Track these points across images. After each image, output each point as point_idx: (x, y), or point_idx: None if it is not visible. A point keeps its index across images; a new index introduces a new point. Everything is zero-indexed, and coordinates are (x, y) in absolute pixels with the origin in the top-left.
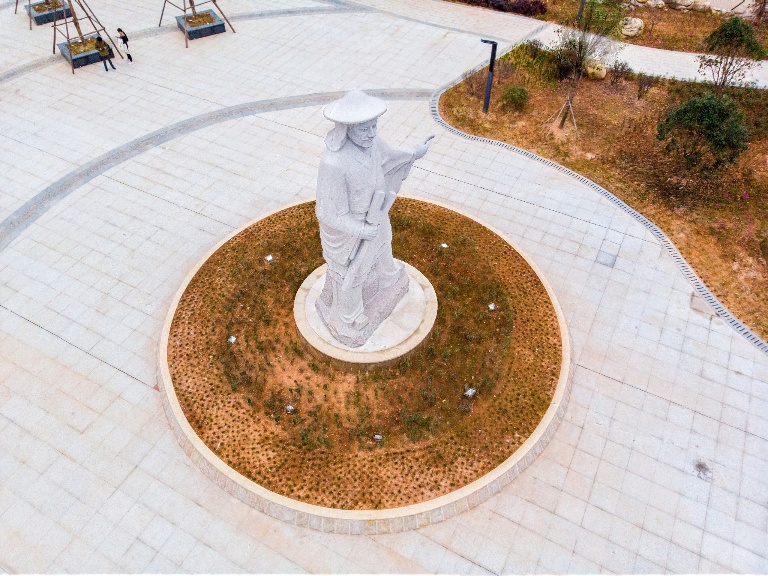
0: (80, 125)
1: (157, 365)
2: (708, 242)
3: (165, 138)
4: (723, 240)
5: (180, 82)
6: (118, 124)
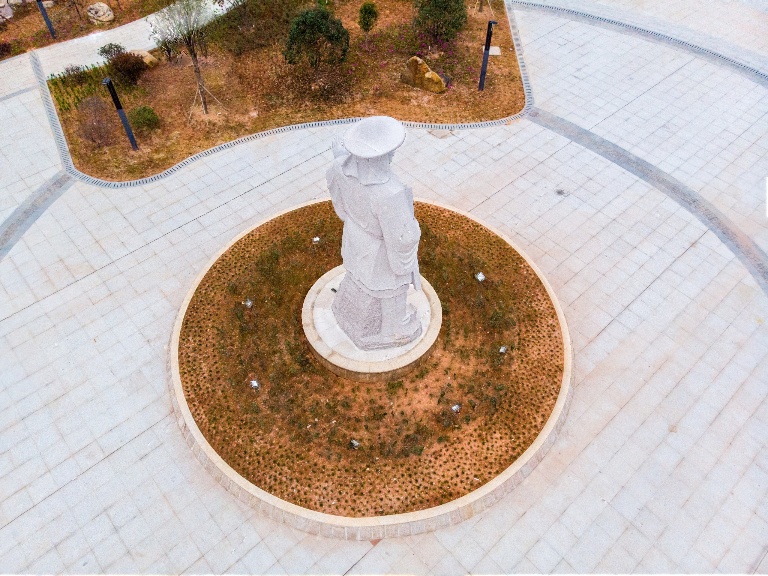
0: None
1: (350, 535)
2: (386, 103)
3: None
4: (389, 95)
5: None
6: None
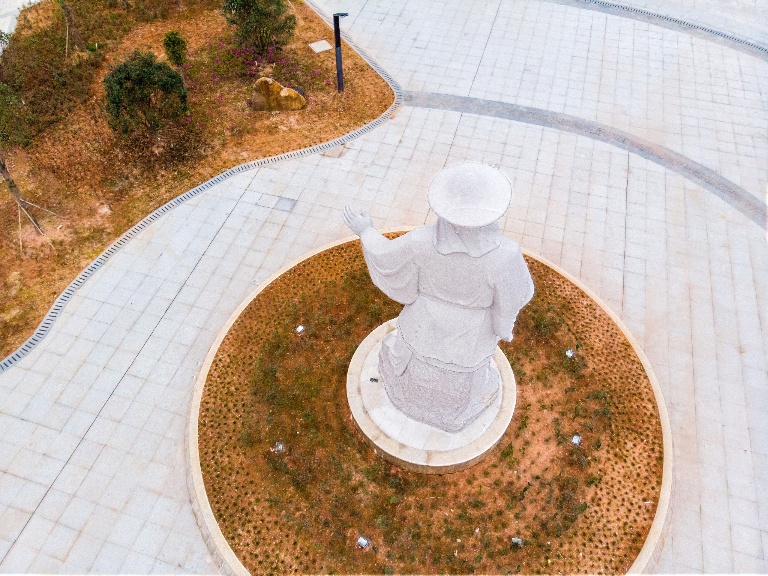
0: None
1: None
2: (253, 139)
3: None
4: (250, 130)
5: None
6: None
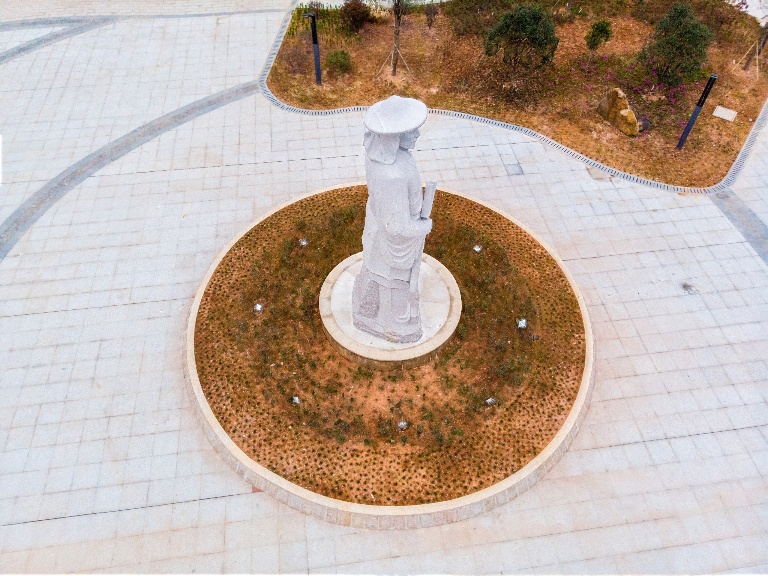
0: None
1: (239, 470)
2: (565, 125)
3: (6, 245)
4: (573, 119)
5: None
6: None
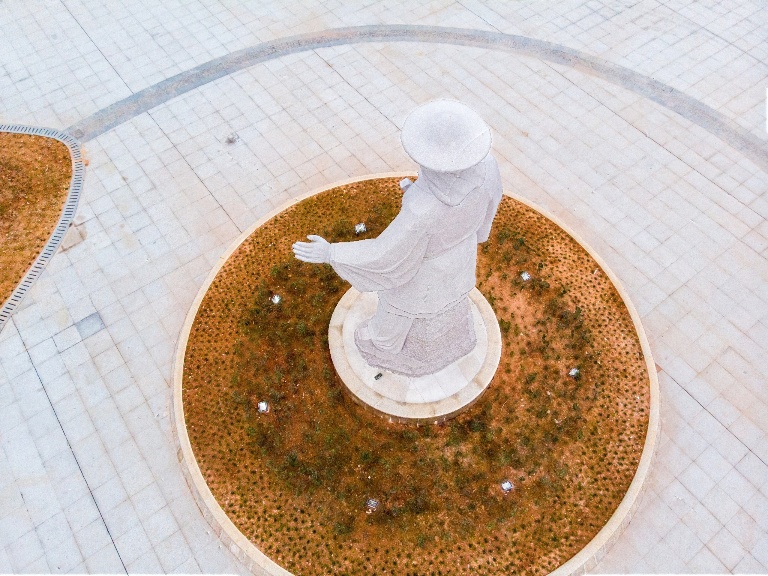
0: None
1: None
2: None
3: None
4: None
5: None
6: None
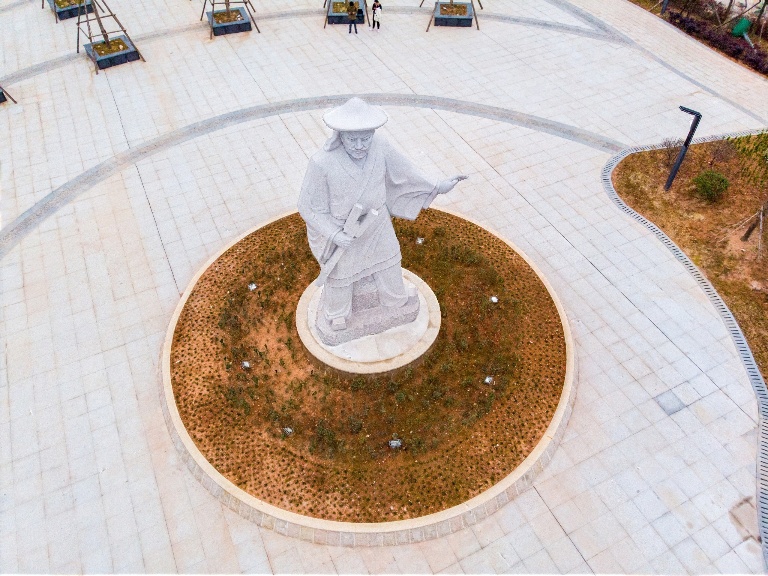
0: (297, 70)
1: None
2: None
3: None
4: None
5: (396, 60)
6: (322, 79)
